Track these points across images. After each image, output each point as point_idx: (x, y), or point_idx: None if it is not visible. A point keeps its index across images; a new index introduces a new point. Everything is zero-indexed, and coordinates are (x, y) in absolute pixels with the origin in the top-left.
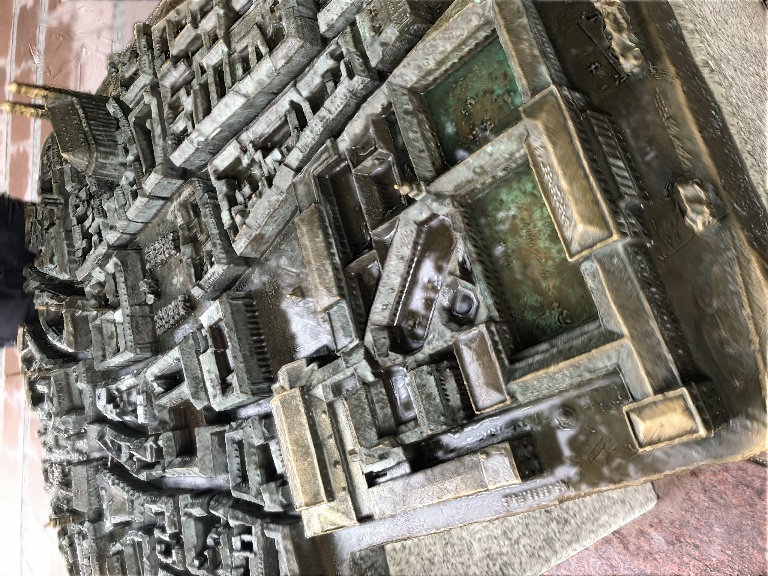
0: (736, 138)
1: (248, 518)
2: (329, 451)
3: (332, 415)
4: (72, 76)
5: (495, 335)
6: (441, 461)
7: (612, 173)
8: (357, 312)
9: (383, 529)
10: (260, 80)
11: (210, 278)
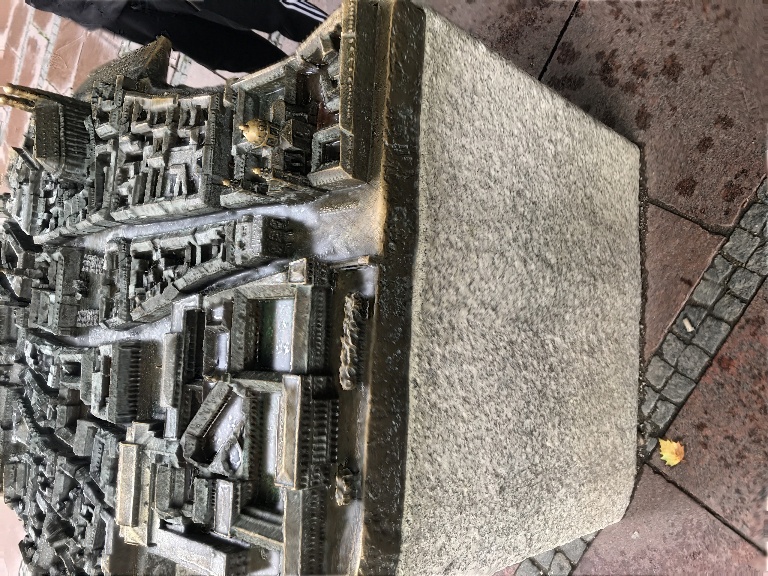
0: (409, 437)
1: (94, 499)
2: (144, 494)
3: (153, 471)
4: (74, 51)
5: (239, 491)
6: (203, 534)
7: (312, 446)
8: (184, 417)
9: None
10: (177, 208)
11: (113, 323)
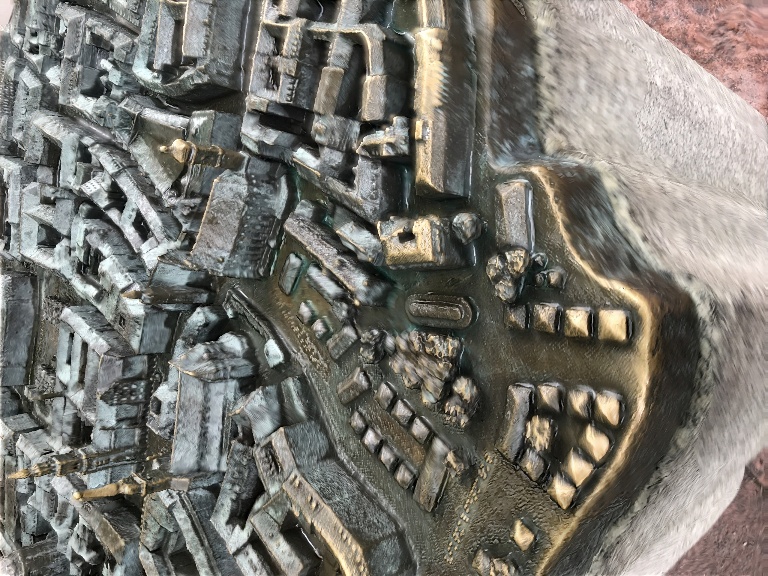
0: None
1: None
2: None
3: None
4: None
5: None
6: None
7: None
8: None
9: (7, 30)
10: None
11: None
